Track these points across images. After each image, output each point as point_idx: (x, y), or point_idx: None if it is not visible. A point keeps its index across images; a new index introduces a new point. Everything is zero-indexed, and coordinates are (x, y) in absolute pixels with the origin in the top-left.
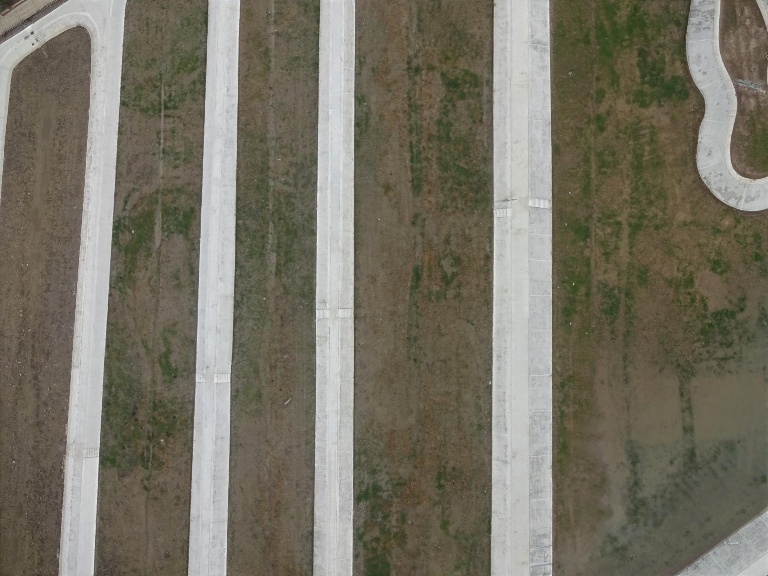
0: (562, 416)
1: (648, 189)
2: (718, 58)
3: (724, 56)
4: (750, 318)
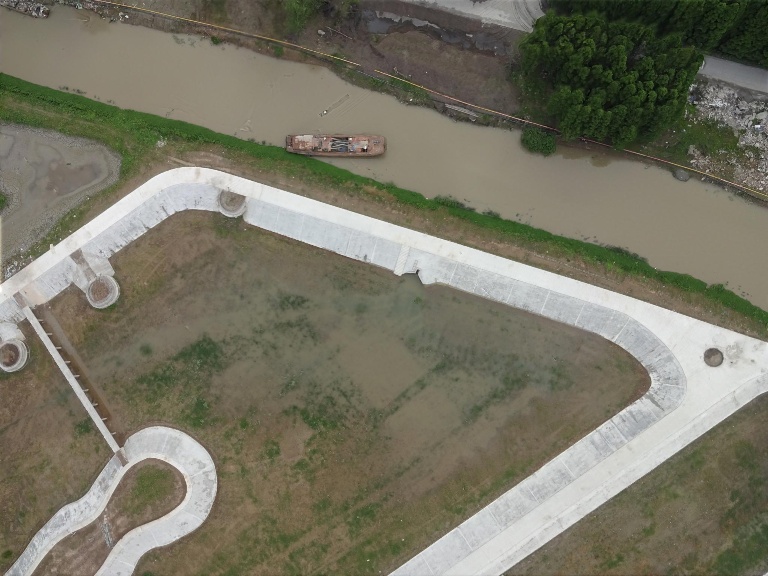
0: (485, 494)
1: (246, 552)
2: (100, 574)
3: (95, 570)
4: (297, 397)
